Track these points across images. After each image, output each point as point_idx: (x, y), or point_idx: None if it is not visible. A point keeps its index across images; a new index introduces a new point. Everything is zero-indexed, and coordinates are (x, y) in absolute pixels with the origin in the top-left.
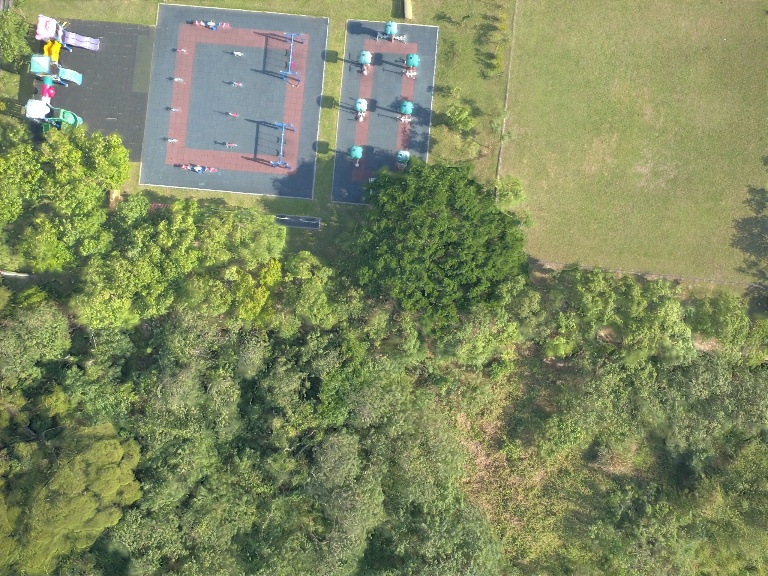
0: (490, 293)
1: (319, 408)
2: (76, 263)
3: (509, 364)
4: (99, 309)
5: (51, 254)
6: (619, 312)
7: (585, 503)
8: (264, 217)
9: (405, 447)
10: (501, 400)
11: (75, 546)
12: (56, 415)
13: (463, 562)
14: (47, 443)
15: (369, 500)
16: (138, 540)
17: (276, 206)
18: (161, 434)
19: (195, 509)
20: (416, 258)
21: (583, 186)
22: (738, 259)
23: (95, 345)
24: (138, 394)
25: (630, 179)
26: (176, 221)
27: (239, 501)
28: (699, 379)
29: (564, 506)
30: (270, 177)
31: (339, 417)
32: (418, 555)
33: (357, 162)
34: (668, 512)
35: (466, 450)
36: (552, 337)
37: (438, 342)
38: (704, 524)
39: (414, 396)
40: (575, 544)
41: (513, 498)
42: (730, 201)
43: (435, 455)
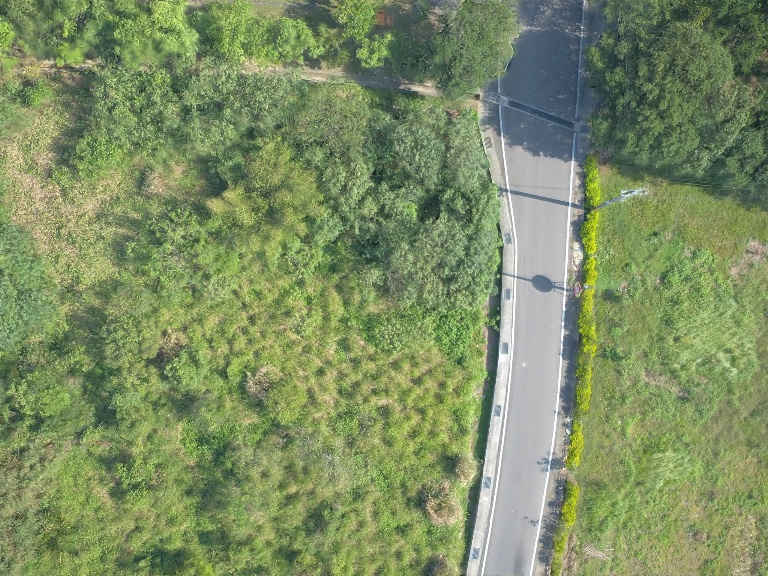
0: None
1: None
2: None
3: (41, 86)
4: None
5: None
6: (108, 8)
7: (132, 225)
8: None
9: None
10: (48, 129)
11: None
12: None
13: None
14: None
15: None
16: None
17: None
18: None
19: None
20: None
21: None
22: None
23: None
24: None
25: None
26: None
27: None
28: (200, 75)
29: (112, 230)
30: None
31: None
32: None
33: None
34: (188, 214)
35: (20, 183)
36: (57, 43)
37: None
38: (229, 228)
39: None
40: (128, 269)
41: (64, 225)
42: None
43: None
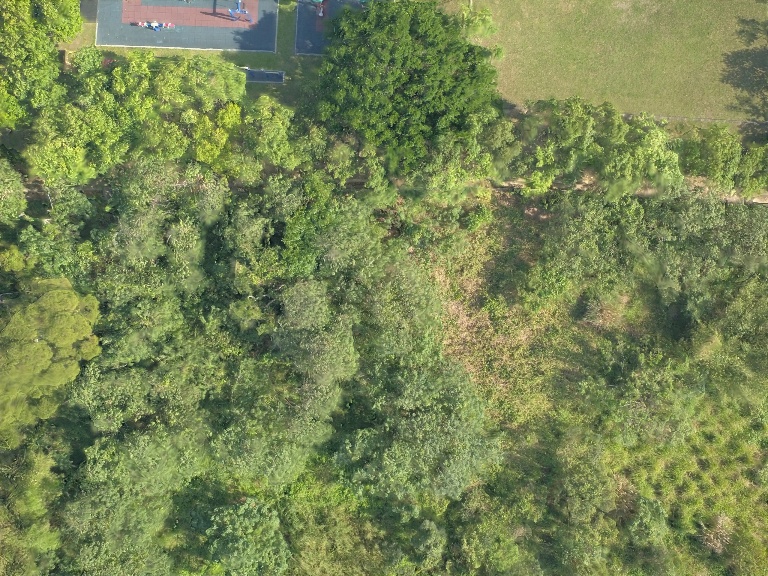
0: (460, 123)
1: (284, 254)
2: (29, 121)
3: (487, 212)
4: (51, 159)
5: (1, 107)
6: (599, 138)
7: (574, 360)
8: (222, 64)
9: (376, 290)
10: (481, 255)
11: (40, 423)
12: (15, 284)
13: (444, 417)
14: (1, 302)
15: (339, 346)
16: (98, 399)
17: (238, 61)
18: (120, 290)
19: (158, 369)
20: (379, 84)
21: (560, 25)
22: (729, 95)
23: (51, 205)
24: (97, 254)
25: (610, 15)
26: (129, 66)
27: (204, 359)
28: (689, 210)
29: (552, 364)
30: (231, 31)
31: (306, 265)
32: (395, 411)
33: (321, 12)
34: (662, 358)
35: (446, 310)
36: (530, 173)
37: (407, 179)
38: (702, 372)
39: (386, 244)
40: (566, 406)
41: (498, 358)
42: (718, 34)
43: (408, 299)
